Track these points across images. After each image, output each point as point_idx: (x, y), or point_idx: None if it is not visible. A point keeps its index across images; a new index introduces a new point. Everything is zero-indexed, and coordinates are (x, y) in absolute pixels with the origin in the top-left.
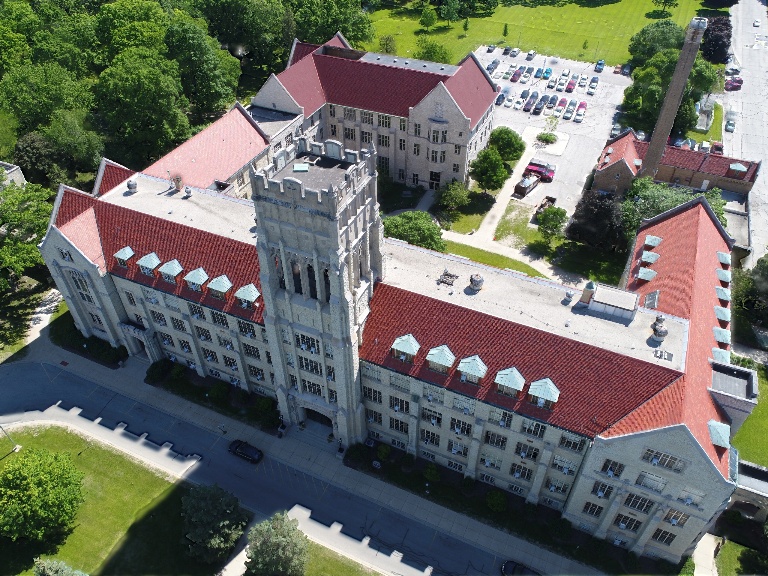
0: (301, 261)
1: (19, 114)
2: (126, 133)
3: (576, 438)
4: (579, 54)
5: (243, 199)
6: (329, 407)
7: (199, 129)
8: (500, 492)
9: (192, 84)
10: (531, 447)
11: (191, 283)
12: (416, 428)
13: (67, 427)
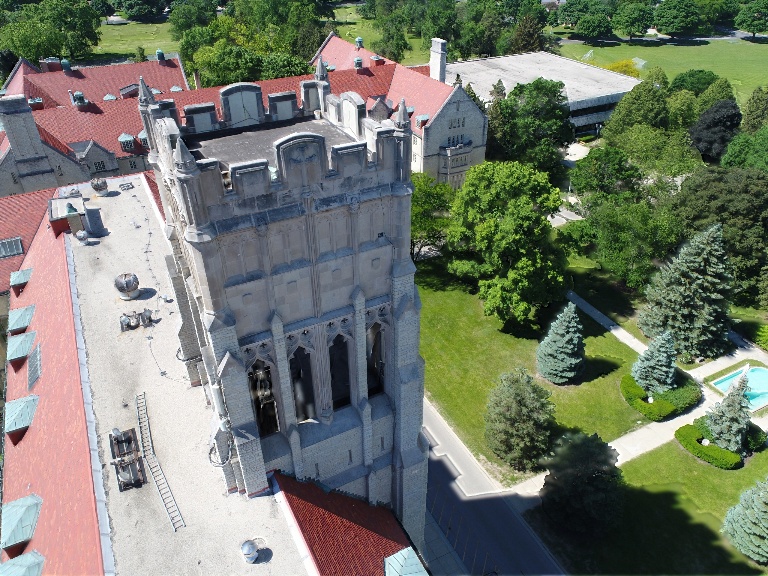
0: None
1: None
2: None
3: None
4: None
5: None
6: None
7: None
8: None
9: None
10: None
11: None
12: None
13: None
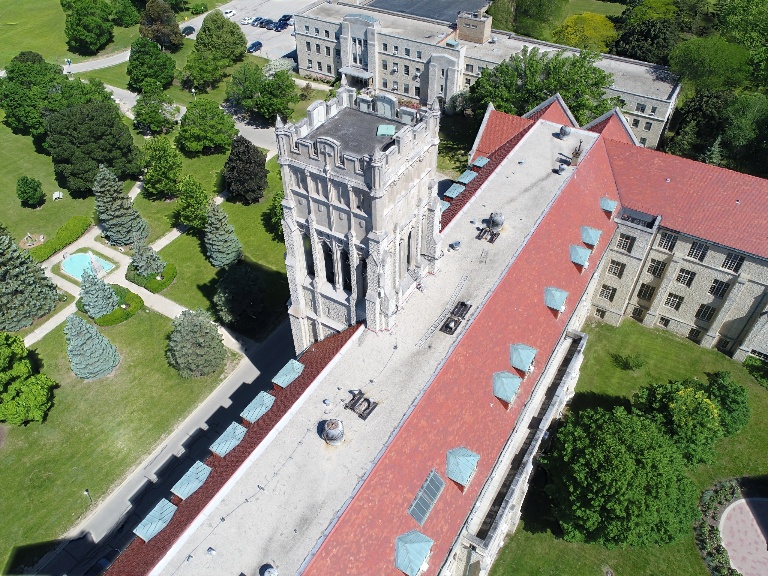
0: None
1: None
2: None
3: None
4: None
5: None
6: None
7: None
8: None
9: None
10: None
11: None
12: None
13: None
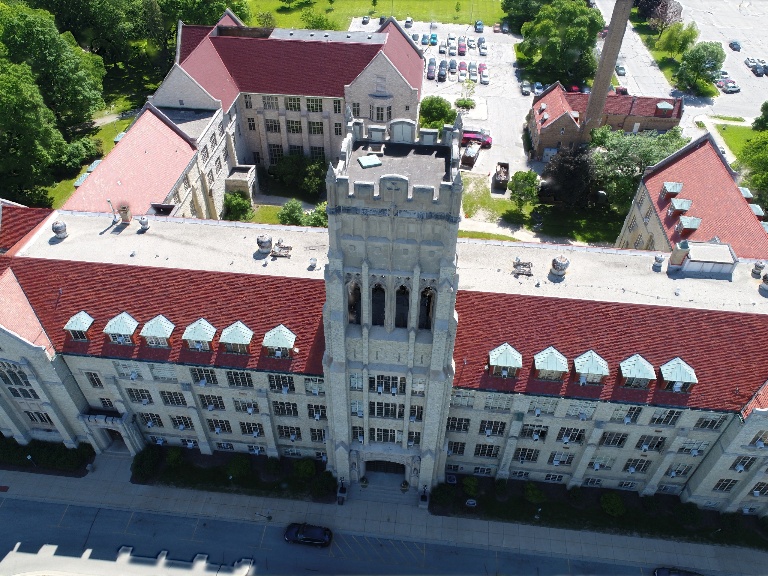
0: (392, 284)
1: None
2: None
3: (716, 416)
4: (453, 17)
5: None
6: (408, 453)
7: (74, 146)
8: (614, 493)
9: (50, 92)
10: (656, 437)
11: (194, 342)
12: (514, 449)
13: None
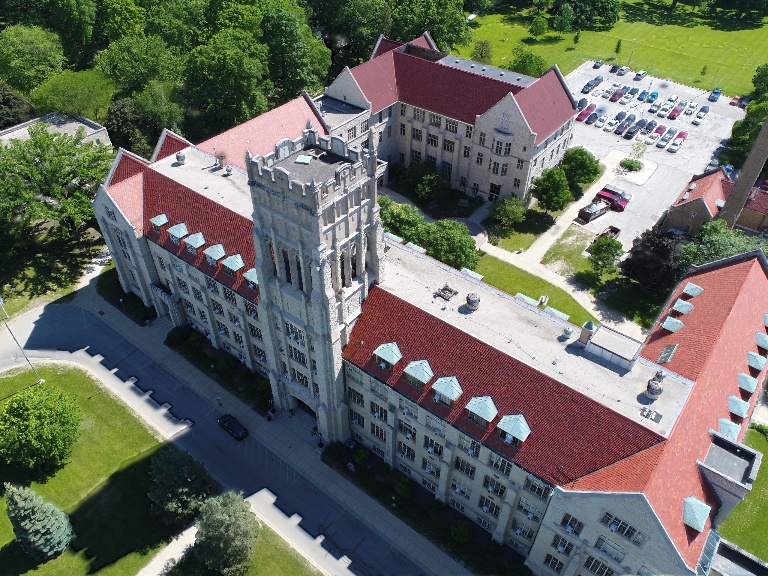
0: (290, 251)
1: (118, 80)
2: (207, 109)
3: (541, 484)
4: (695, 80)
5: None
6: (313, 400)
7: None
8: (466, 522)
9: (280, 69)
10: (498, 483)
11: (209, 257)
12: (392, 438)
13: (87, 371)
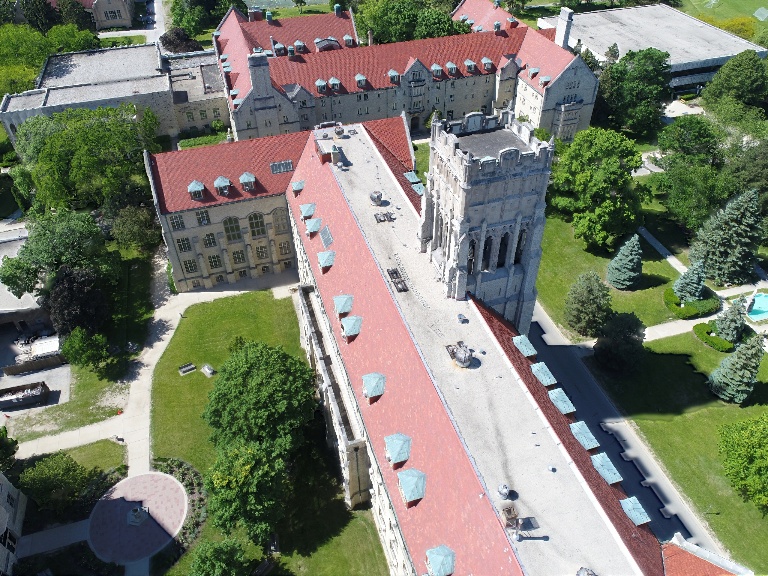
0: None
1: None
2: None
3: None
4: None
5: (415, 484)
6: None
7: None
8: None
9: None
10: None
11: None
12: None
13: None
